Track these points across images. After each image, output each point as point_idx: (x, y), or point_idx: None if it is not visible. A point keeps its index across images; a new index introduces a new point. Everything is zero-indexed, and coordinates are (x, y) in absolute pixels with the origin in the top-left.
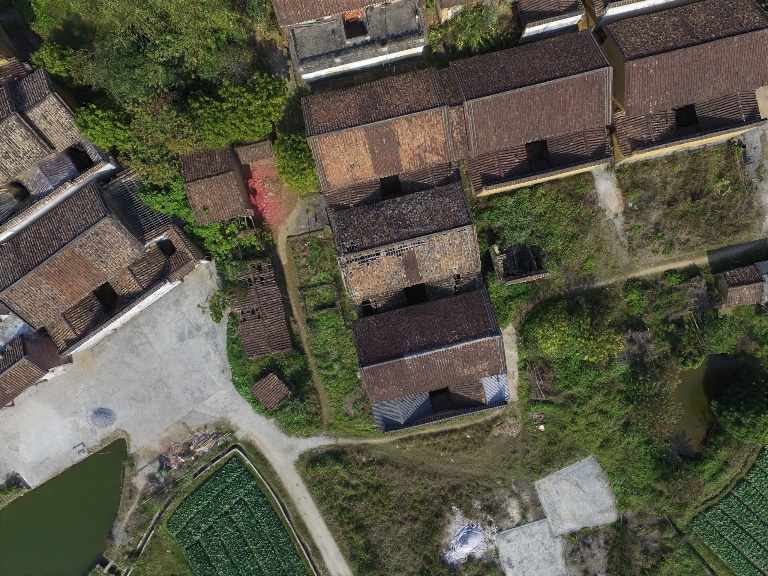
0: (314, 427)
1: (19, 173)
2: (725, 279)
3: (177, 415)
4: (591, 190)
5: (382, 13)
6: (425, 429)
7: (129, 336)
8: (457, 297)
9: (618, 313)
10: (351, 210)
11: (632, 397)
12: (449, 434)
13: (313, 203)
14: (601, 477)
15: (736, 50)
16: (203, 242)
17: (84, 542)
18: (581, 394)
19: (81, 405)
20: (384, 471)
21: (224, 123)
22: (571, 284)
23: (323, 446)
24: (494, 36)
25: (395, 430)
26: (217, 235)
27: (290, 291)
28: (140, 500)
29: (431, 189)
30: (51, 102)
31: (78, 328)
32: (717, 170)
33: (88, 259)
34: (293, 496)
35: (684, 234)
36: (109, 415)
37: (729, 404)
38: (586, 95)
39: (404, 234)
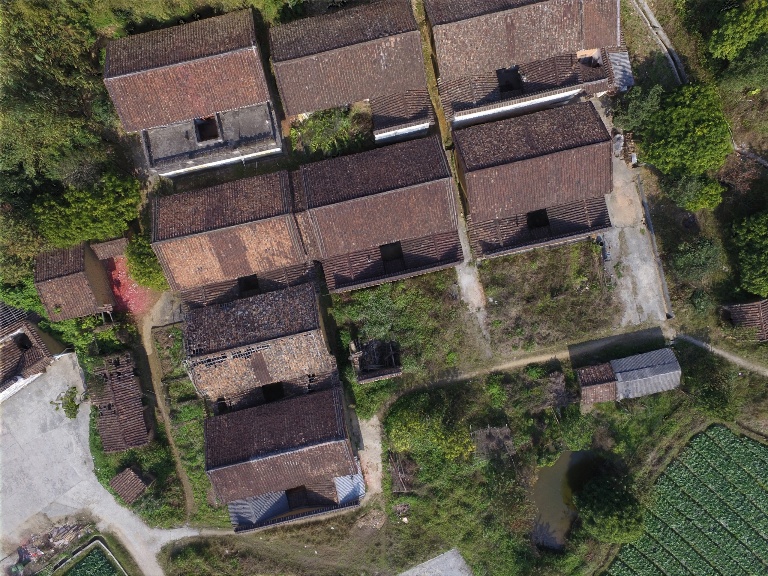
0: (176, 519)
1: None
2: (580, 377)
3: (38, 506)
4: (452, 285)
5: (236, 116)
6: None
7: None
8: (309, 396)
9: (479, 407)
10: (203, 309)
11: (490, 493)
12: (312, 526)
13: (178, 294)
14: (464, 570)
15: (575, 161)
16: (61, 336)
17: None
18: (443, 487)
19: None
20: (246, 563)
21: (68, 228)
22: (435, 376)
23: (186, 537)
24: (347, 139)
25: (246, 530)
26: (74, 330)
27: (155, 381)
28: None
29: (283, 289)
30: None
31: None
32: (577, 266)
33: None
34: None
35: (544, 329)
36: None
37: (586, 500)
38: (430, 203)
39: (250, 337)
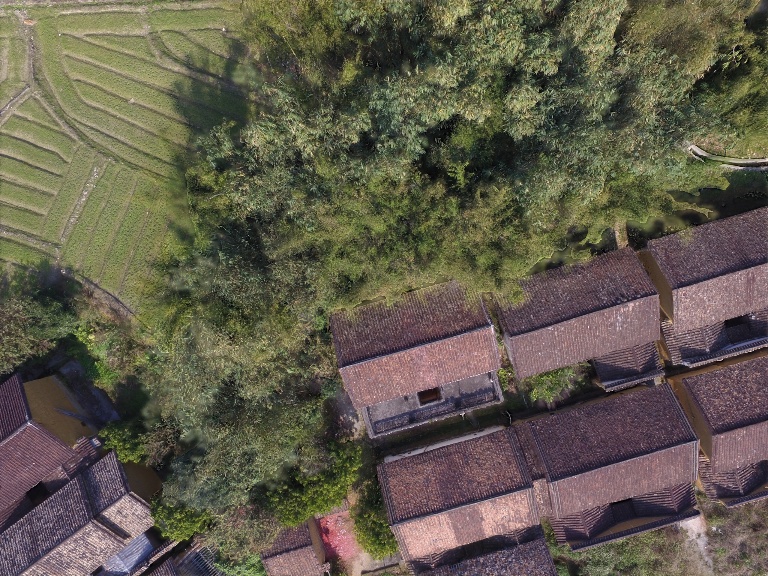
0: None
1: (96, 568)
2: None
3: None
4: None
5: None
6: None
7: None
8: None
9: None
10: (433, 573)
11: None
12: None
13: None
14: None
15: None
16: None
17: None
18: None
19: None
20: None
21: None
22: None
23: None
24: (569, 387)
25: None
26: None
27: None
28: None
29: (514, 548)
30: (127, 500)
31: None
32: None
33: None
34: None
35: None
36: None
37: None
38: (672, 462)
39: None
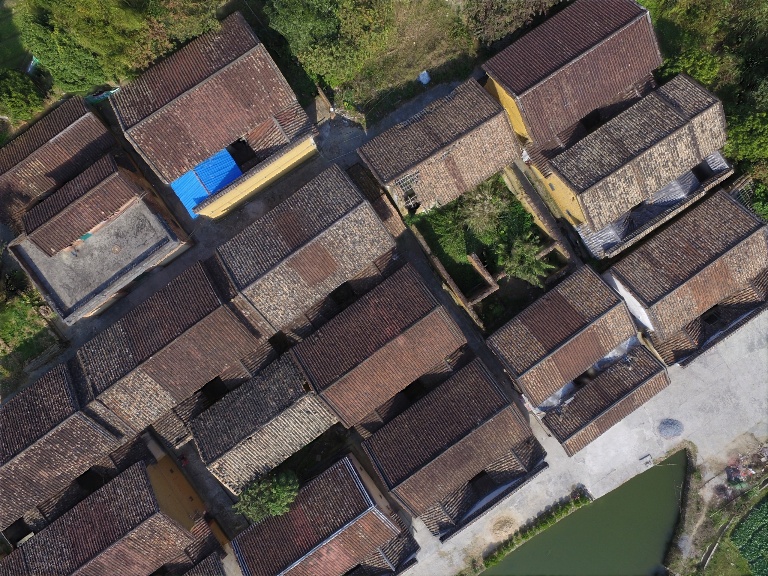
0: None
1: (669, 182)
2: None
3: (745, 426)
4: None
5: None
6: None
7: None
8: None
9: None
10: None
11: None
12: None
13: None
14: None
15: None
16: None
17: (640, 555)
18: None
19: (648, 416)
20: None
21: None
22: None
23: None
24: None
25: None
26: None
27: None
28: (708, 512)
29: None
30: (714, 110)
31: (695, 339)
32: None
33: (730, 269)
34: None
35: None
36: (678, 426)
37: None
38: None
39: None
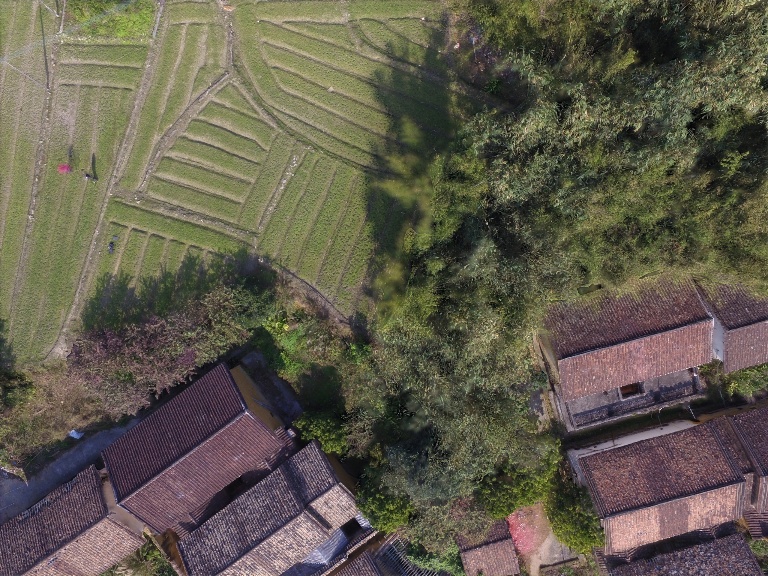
0: None
1: (299, 559)
2: None
3: None
4: None
5: None
6: None
7: None
8: None
9: None
10: (630, 567)
11: None
12: None
13: None
14: None
15: None
16: None
17: None
18: None
19: None
20: None
21: None
22: None
23: None
24: None
25: None
26: None
27: None
28: None
29: (711, 542)
30: (335, 491)
31: None
32: None
33: None
34: None
35: None
36: None
37: None
38: None
39: None
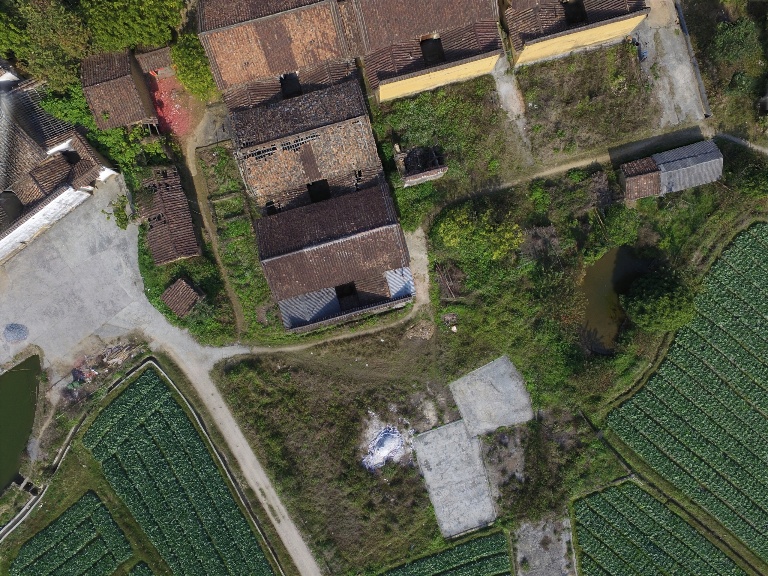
0: (227, 335)
1: None
2: (623, 170)
3: (90, 328)
4: (491, 91)
5: None
6: (339, 335)
7: (40, 251)
8: (358, 193)
9: (523, 211)
10: (250, 110)
11: (538, 291)
12: (362, 338)
13: (220, 114)
14: (515, 376)
15: None
16: (109, 151)
17: (0, 462)
18: (491, 293)
19: None
20: (299, 377)
21: (116, 22)
22: (477, 186)
23: (238, 355)
24: None
25: (300, 327)
26: (121, 143)
27: (200, 202)
28: (54, 415)
29: (328, 88)
30: None
31: None
32: (614, 69)
33: None
34: (209, 406)
35: (584, 132)
36: (21, 330)
37: (634, 295)
38: None
39: (299, 128)
